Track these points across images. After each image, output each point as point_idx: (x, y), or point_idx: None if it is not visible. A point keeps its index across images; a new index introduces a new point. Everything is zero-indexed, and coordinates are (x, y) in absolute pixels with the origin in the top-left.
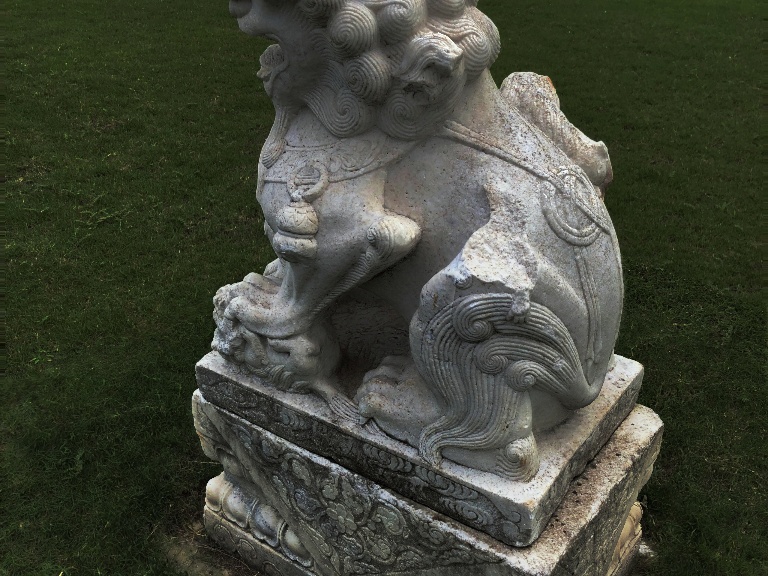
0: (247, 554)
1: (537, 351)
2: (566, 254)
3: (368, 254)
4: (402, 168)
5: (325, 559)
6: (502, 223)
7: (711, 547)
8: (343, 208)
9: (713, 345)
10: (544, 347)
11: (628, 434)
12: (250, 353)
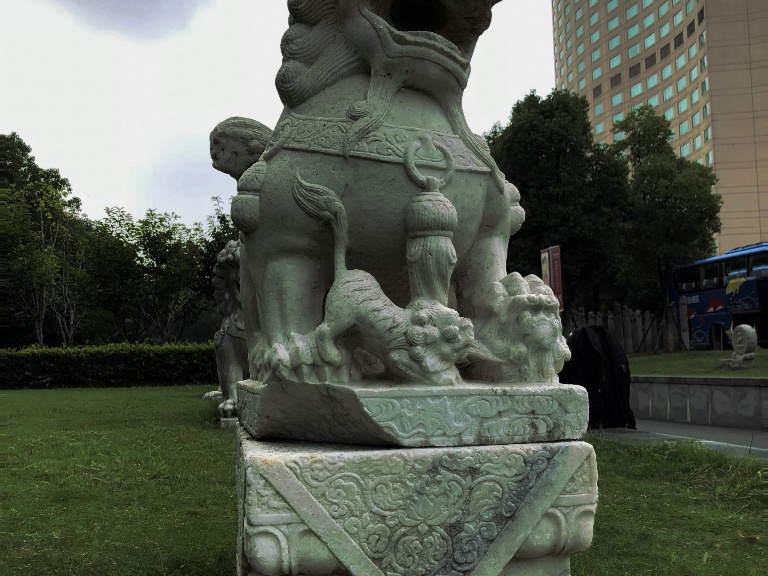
0: None
1: None
2: None
3: None
4: None
5: None
6: None
7: None
8: None
9: None
10: None
11: None
12: None
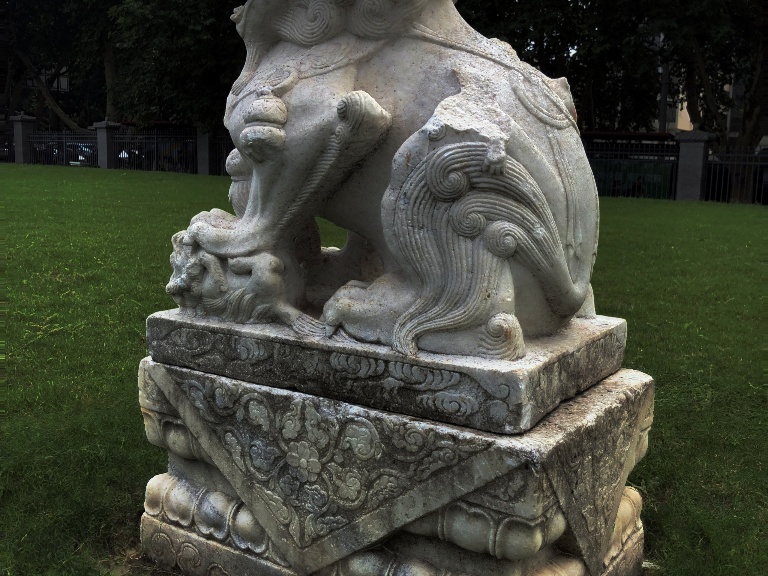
0: (189, 563)
1: (516, 211)
2: (538, 130)
3: (338, 128)
4: (372, 66)
5: (283, 530)
6: (473, 95)
7: (723, 549)
8: (313, 97)
9: (693, 409)
10: (523, 208)
11: (617, 381)
12: (208, 280)
